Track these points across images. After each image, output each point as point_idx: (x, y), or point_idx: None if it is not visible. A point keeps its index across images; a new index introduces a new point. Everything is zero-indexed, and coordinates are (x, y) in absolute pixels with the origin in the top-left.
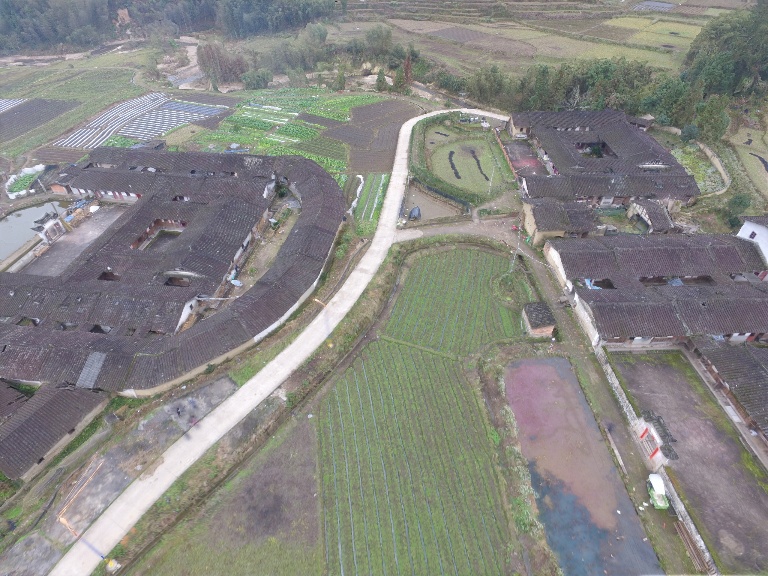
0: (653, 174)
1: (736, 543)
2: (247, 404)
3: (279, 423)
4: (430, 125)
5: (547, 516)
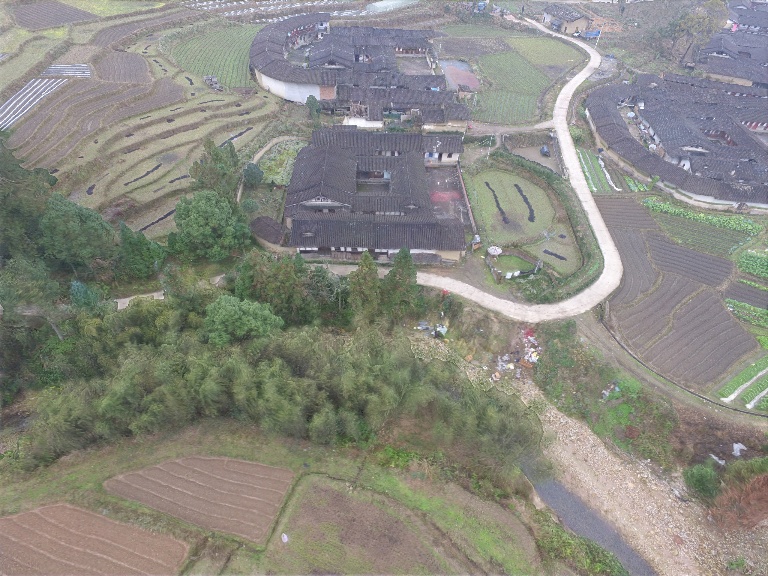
0: (344, 139)
1: (416, 61)
2: (579, 76)
3: (563, 76)
4: (580, 269)
5: (469, 67)
